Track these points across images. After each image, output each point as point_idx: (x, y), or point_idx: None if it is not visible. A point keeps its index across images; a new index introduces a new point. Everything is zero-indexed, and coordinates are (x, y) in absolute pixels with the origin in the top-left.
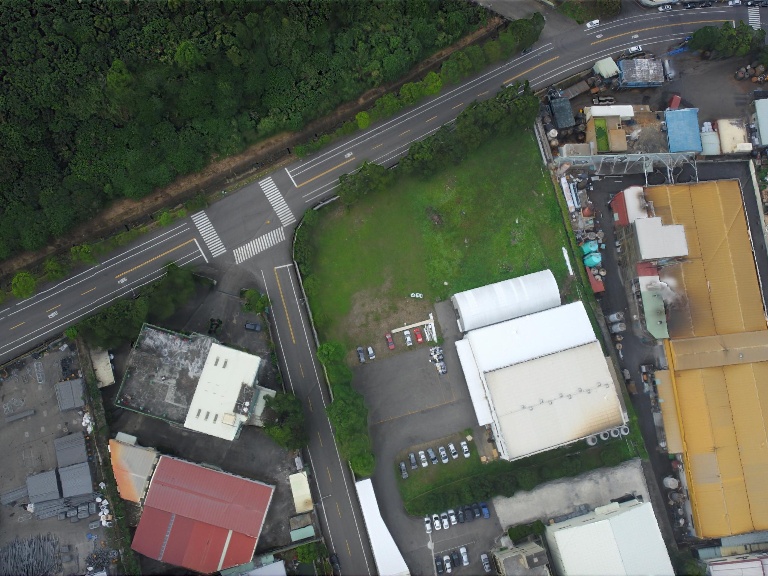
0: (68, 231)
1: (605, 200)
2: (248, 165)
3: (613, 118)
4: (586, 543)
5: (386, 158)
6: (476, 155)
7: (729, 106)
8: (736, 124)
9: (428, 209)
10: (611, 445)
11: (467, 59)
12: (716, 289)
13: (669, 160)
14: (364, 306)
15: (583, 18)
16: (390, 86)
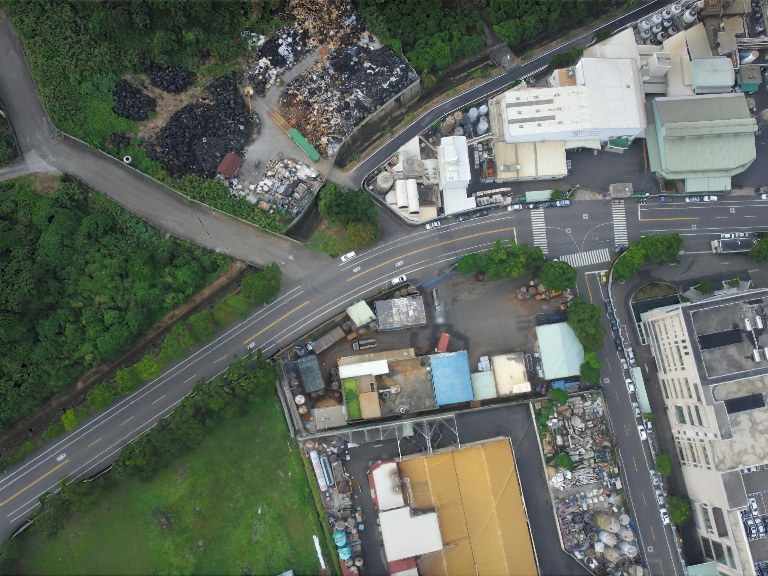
0: None
1: (364, 469)
2: None
3: (366, 376)
4: None
5: (106, 455)
6: (212, 436)
7: (510, 333)
8: (514, 359)
9: (155, 511)
10: None
11: (187, 335)
12: (485, 574)
13: (425, 427)
14: None
15: (337, 250)
16: (114, 362)
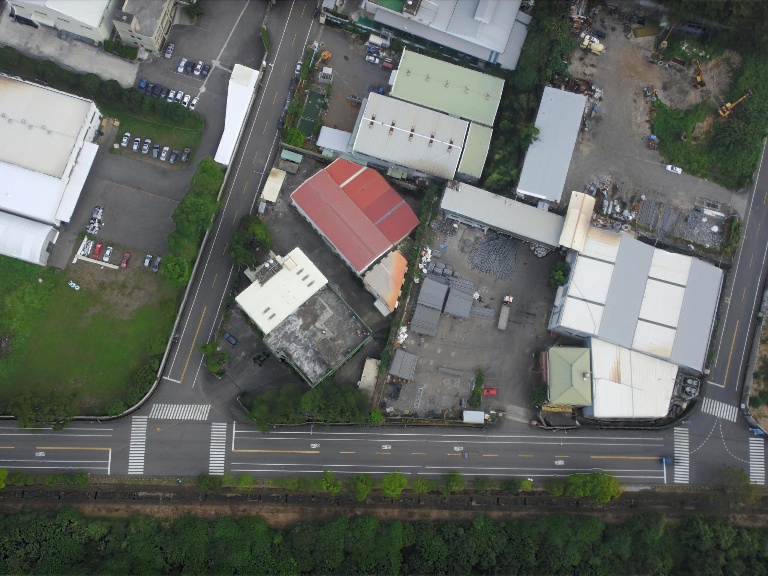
0: (335, 518)
1: None
2: (143, 501)
3: None
4: (77, 4)
5: (7, 431)
6: None
7: None
8: None
9: (5, 357)
10: (4, 67)
11: None
12: None
13: None
14: (127, 304)
15: None
16: None
